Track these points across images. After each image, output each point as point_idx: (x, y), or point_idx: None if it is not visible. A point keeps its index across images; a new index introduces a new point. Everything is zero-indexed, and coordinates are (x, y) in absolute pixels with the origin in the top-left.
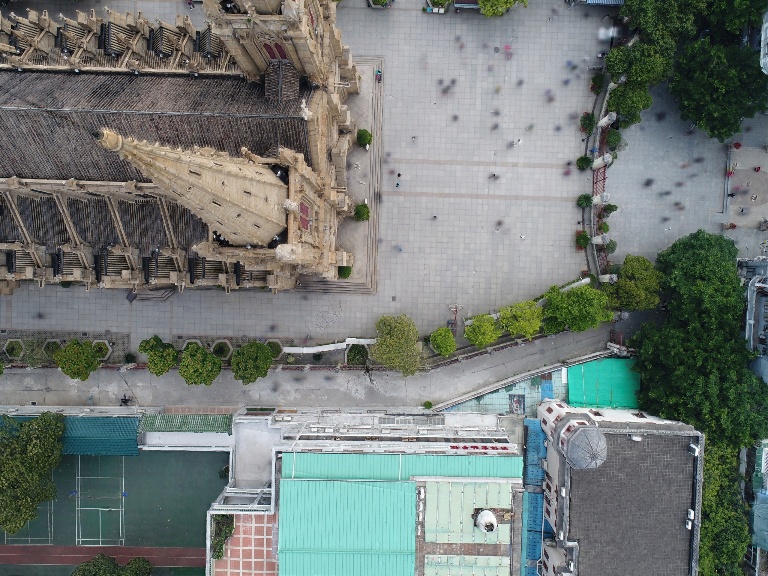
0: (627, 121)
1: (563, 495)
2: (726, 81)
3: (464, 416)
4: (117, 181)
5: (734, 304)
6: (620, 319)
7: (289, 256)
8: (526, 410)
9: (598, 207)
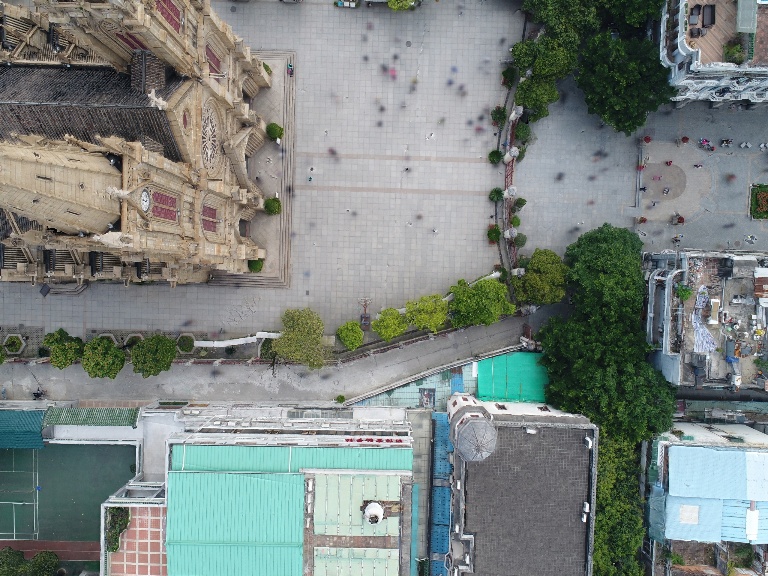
0: (536, 115)
1: (458, 488)
2: (626, 74)
3: (373, 410)
4: None
5: (633, 297)
6: (529, 313)
7: (117, 244)
8: (436, 404)
9: (509, 201)
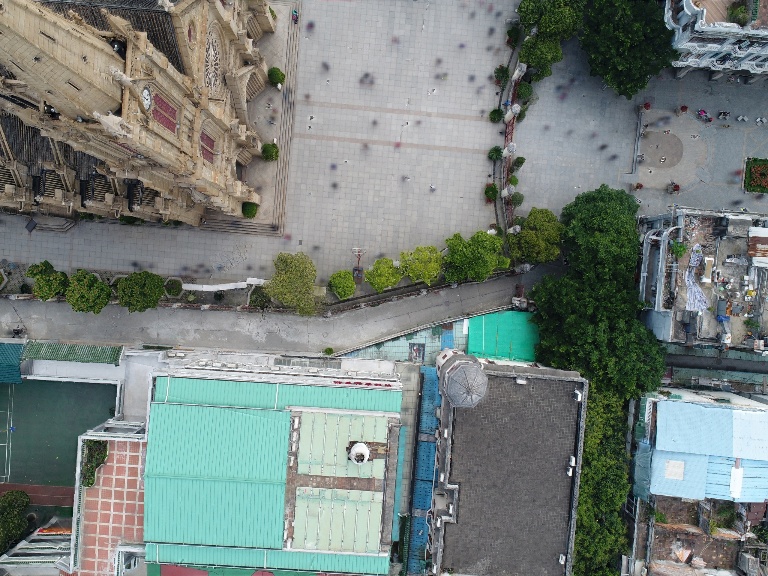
0: (539, 74)
1: (445, 436)
2: (631, 35)
3: (361, 361)
4: None
5: (628, 255)
6: (522, 271)
7: (117, 128)
8: (425, 359)
9: (508, 160)
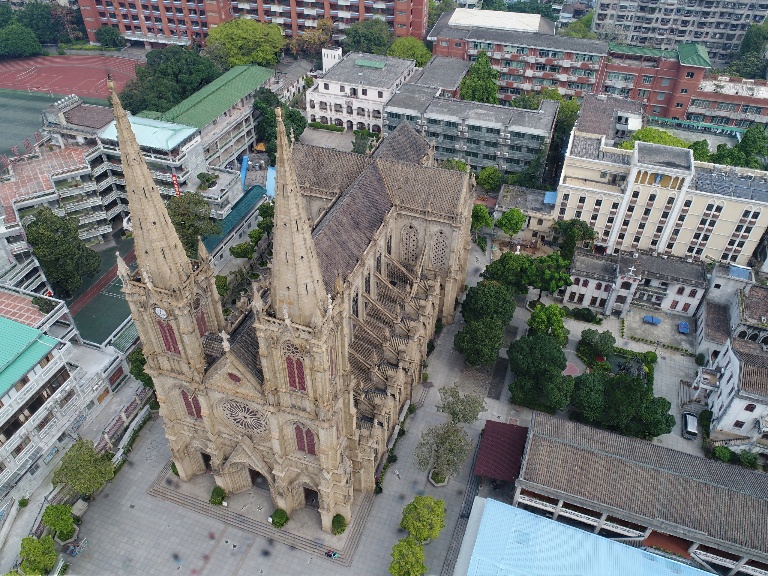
0: None
1: None
2: None
3: None
4: None
5: None
6: None
7: None
8: None
9: None
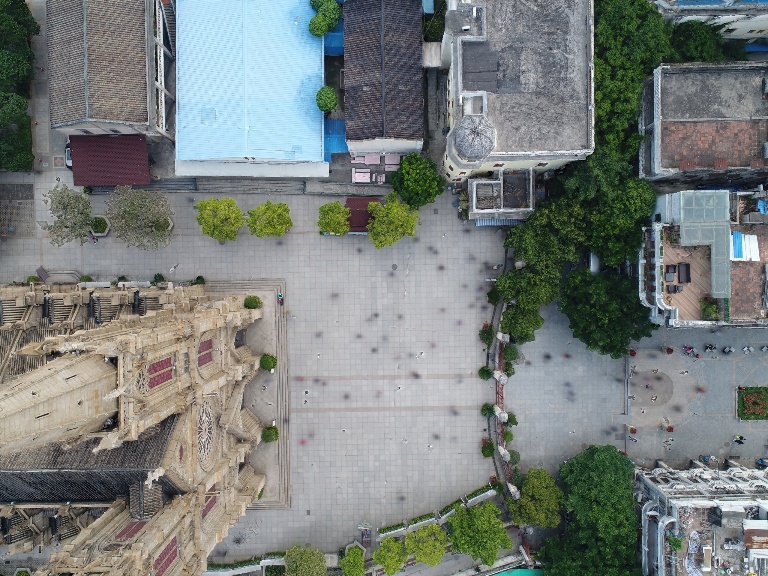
0: (522, 337)
1: None
2: (608, 313)
3: None
4: None
5: (627, 533)
6: (526, 532)
7: None
8: None
9: None
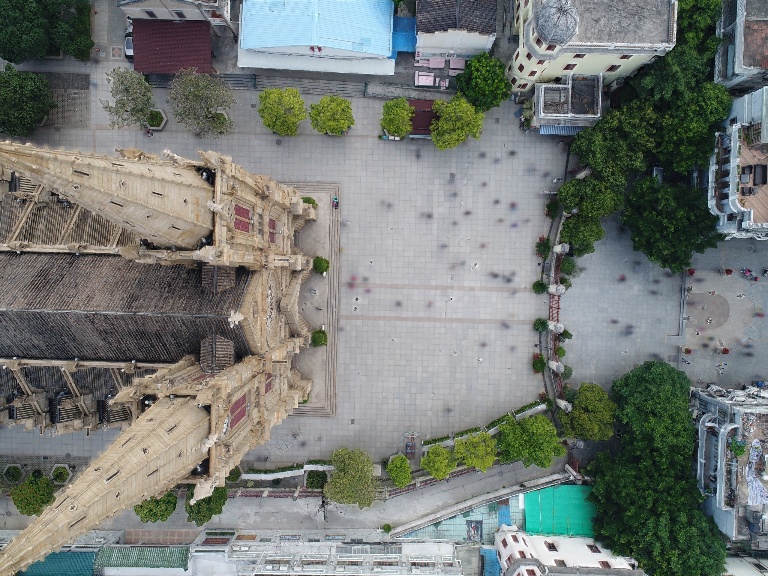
0: (581, 250)
1: None
2: (675, 221)
3: (421, 545)
4: (59, 359)
5: (684, 444)
6: (576, 447)
7: (208, 494)
8: (483, 536)
9: (554, 332)
